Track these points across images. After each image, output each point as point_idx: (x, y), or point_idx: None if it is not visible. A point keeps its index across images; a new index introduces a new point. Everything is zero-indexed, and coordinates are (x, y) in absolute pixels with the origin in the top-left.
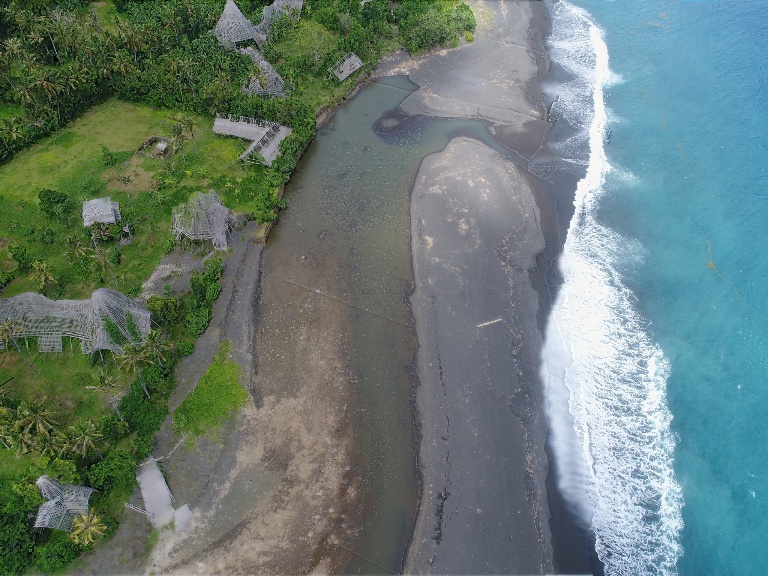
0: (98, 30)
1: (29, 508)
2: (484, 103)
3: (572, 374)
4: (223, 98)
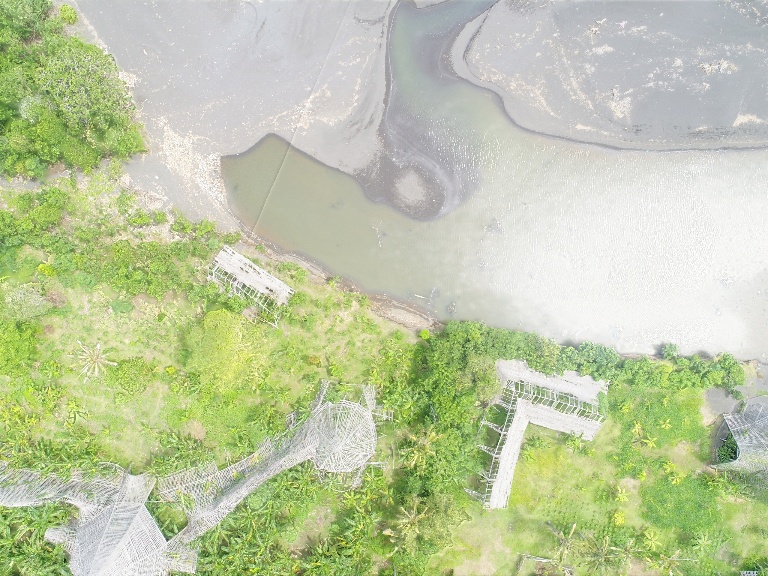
0: None
1: None
2: (339, 8)
3: None
4: None
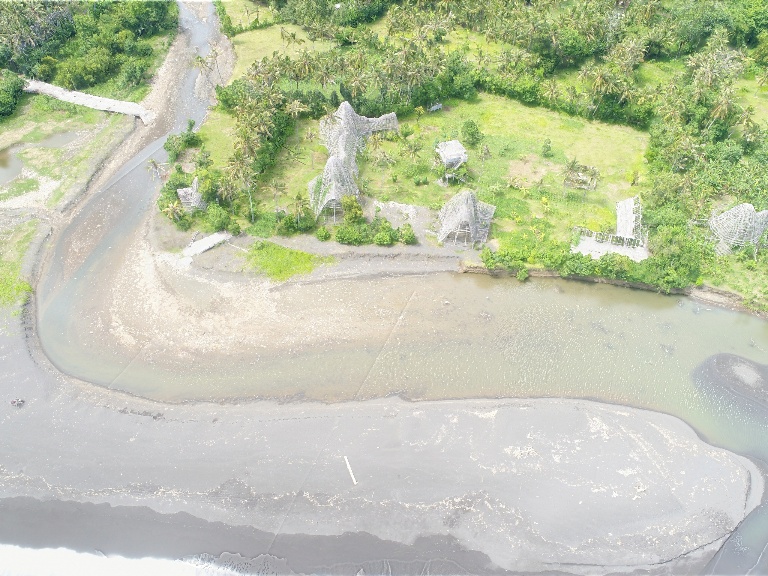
0: (705, 79)
1: None
2: None
3: (277, 567)
4: (663, 192)
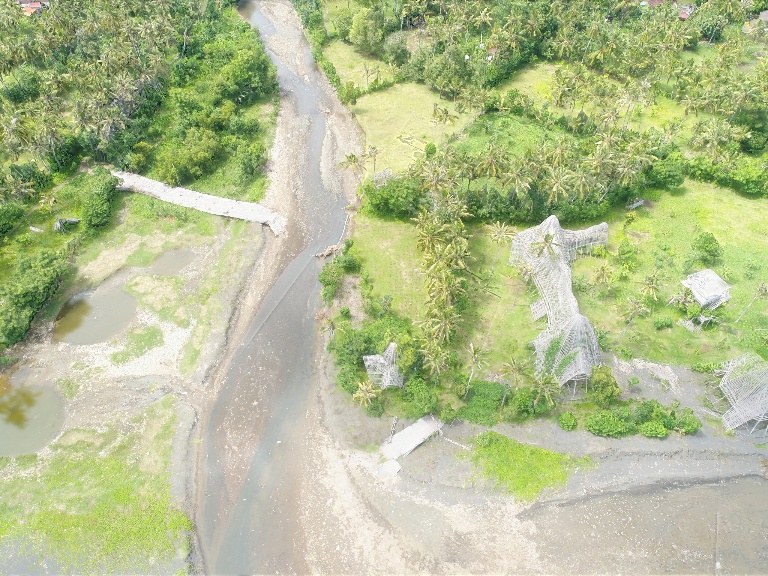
0: None
1: (376, 347)
2: None
3: None
4: None
